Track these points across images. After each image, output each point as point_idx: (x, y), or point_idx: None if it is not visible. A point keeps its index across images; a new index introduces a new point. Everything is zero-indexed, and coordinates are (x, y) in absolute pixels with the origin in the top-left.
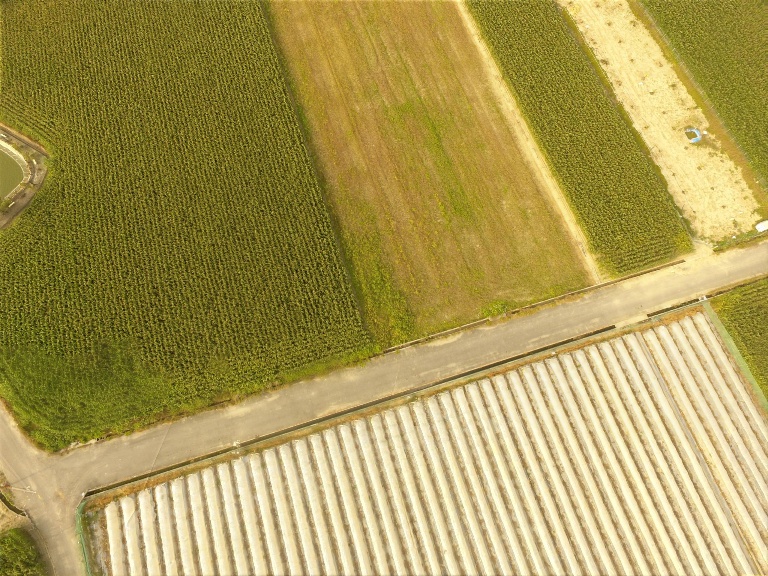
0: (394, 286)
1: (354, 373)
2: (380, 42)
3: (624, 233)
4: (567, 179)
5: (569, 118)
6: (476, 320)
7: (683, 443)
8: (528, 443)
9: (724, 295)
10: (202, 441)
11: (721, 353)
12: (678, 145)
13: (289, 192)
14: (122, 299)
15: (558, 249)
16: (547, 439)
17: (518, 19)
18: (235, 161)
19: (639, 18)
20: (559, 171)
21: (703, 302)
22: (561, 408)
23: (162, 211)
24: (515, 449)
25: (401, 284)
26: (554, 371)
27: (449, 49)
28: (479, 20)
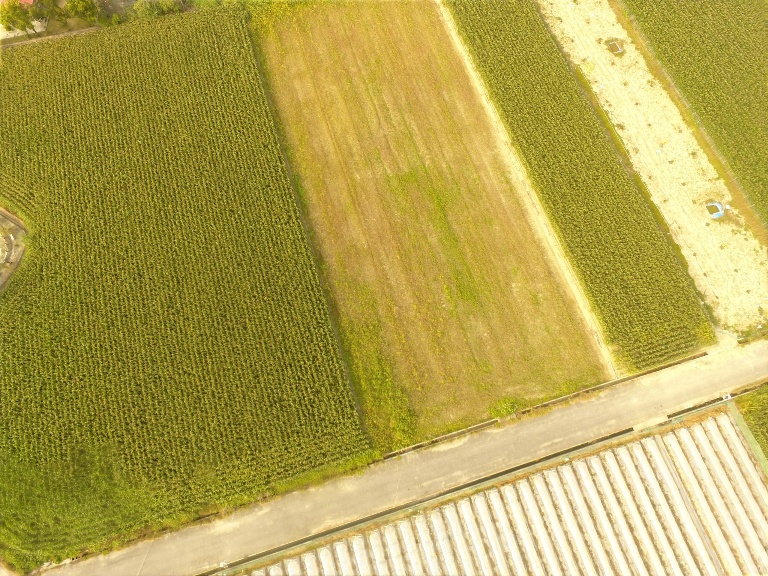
0: (395, 381)
1: (352, 482)
2: (382, 103)
3: (642, 323)
4: (581, 261)
5: (583, 192)
6: (483, 421)
7: (707, 566)
8: (540, 565)
9: (750, 394)
10: (186, 561)
11: (747, 461)
12: (699, 221)
13: (284, 275)
14: (102, 398)
15: (571, 339)
16: (560, 559)
17: (529, 79)
18: (226, 239)
19: (657, 77)
20: (573, 252)
21: (727, 401)
22: (575, 524)
23: (147, 296)
24: (525, 572)
25: (403, 379)
26: (568, 481)
27: (455, 111)
28: (487, 80)
